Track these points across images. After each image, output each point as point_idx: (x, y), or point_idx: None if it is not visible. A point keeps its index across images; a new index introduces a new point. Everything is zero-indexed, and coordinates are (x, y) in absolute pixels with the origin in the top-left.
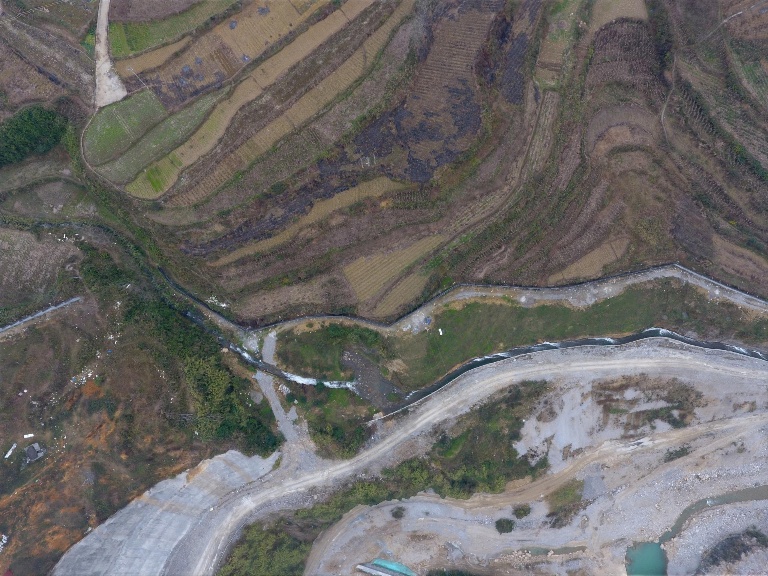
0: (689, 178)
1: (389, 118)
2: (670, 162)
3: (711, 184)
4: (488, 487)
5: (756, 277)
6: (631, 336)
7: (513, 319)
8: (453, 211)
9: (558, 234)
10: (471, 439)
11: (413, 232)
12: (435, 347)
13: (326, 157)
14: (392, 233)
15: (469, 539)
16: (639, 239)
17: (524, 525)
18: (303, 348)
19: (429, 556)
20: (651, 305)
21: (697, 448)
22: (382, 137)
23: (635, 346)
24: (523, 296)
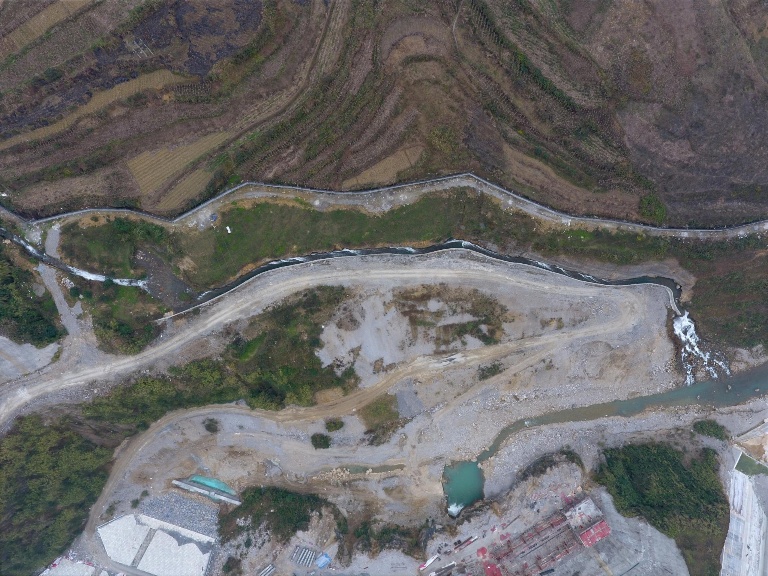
0: (479, 87)
1: (168, 10)
2: (462, 72)
3: (499, 93)
4: (295, 397)
5: (545, 187)
6: (433, 247)
7: (307, 222)
8: (238, 108)
9: (349, 138)
10: (266, 342)
11: (197, 127)
12: (223, 245)
13: (101, 45)
14: (175, 127)
15: (286, 455)
16: (432, 147)
17: (342, 442)
18: (91, 244)
19: (246, 472)
20: (448, 214)
21: (509, 366)
22: (161, 29)
23: (436, 257)
24: (317, 199)
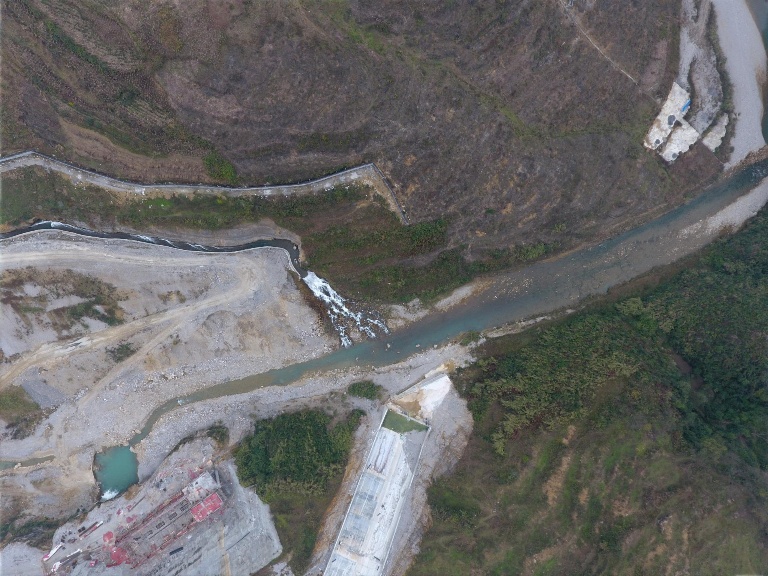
0: (22, 62)
1: None
2: (6, 48)
3: (42, 66)
4: None
5: (108, 158)
6: (19, 230)
7: None
8: None
9: None
10: None
11: None
12: None
13: None
14: None
15: None
16: None
17: None
18: None
19: None
20: (20, 195)
21: (141, 345)
22: None
23: (22, 240)
24: None
